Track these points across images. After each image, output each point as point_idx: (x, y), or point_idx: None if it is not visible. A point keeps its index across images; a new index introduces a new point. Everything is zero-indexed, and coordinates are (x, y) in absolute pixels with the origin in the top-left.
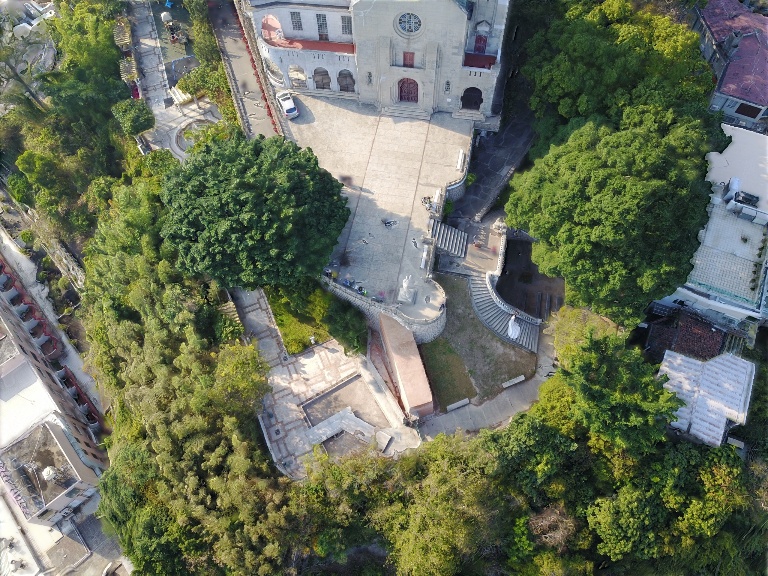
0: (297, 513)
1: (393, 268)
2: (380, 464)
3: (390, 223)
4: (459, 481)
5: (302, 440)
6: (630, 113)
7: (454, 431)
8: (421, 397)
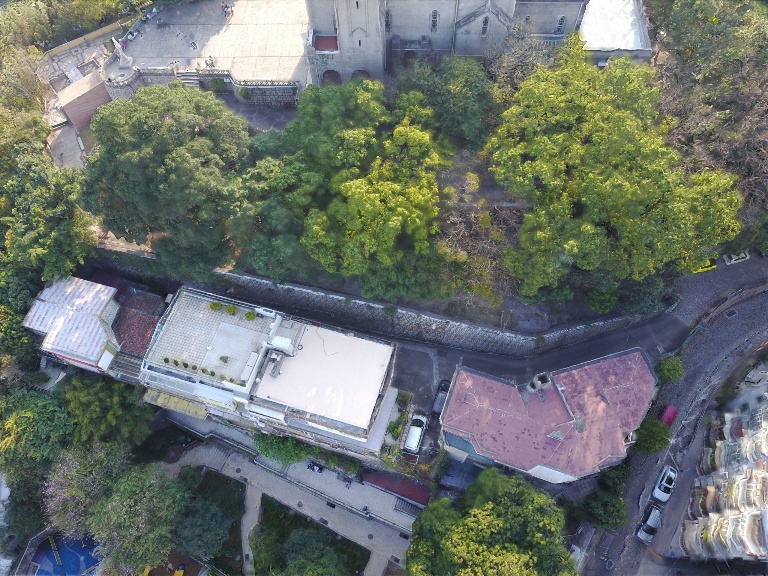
0: (1, 53)
1: (152, 53)
2: (16, 80)
3: (195, 46)
4: (0, 126)
5: (69, 64)
6: (268, 161)
7: (64, 146)
8: (63, 98)
